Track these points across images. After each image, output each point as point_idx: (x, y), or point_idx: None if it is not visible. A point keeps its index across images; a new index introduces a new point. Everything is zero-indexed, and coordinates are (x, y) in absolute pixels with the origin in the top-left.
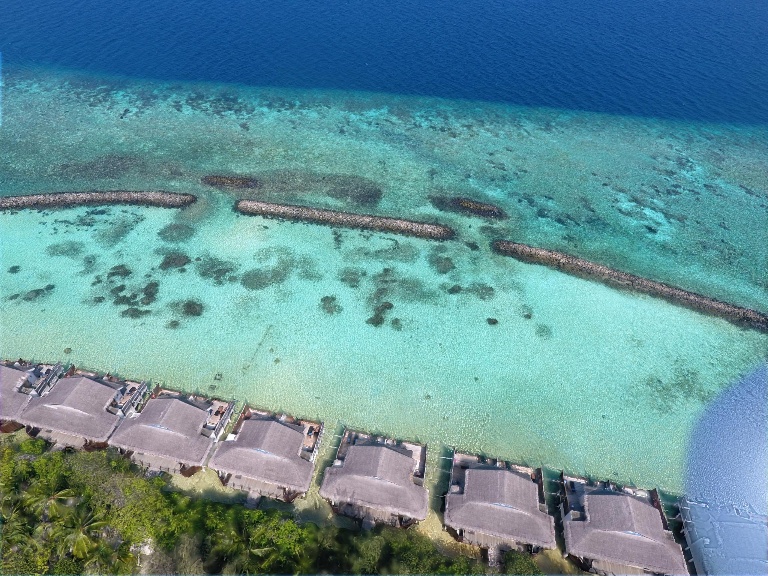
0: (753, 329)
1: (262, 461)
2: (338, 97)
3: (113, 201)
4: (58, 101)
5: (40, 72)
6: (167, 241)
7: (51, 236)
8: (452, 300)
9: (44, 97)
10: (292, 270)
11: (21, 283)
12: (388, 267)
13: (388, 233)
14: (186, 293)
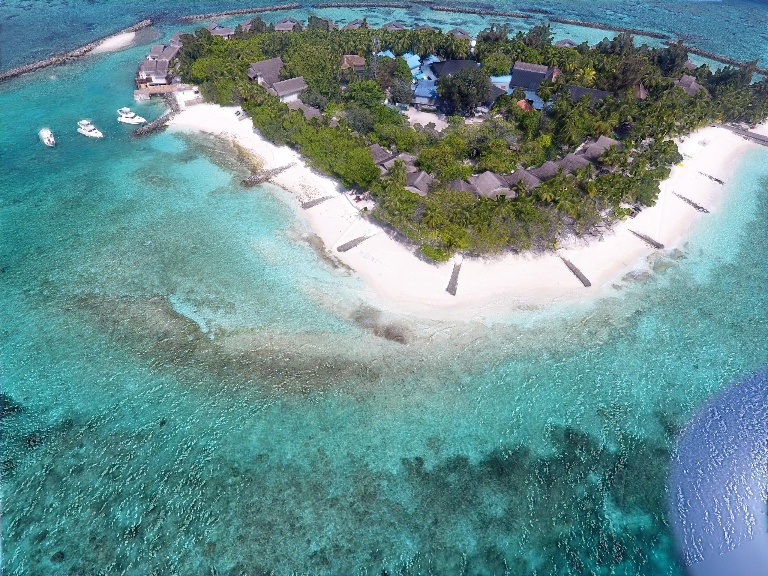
0: (658, 38)
1: None
2: None
3: (377, 6)
4: None
5: None
6: None
7: (361, 13)
8: None
9: None
10: None
11: None
12: (508, 23)
13: (503, 16)
14: None
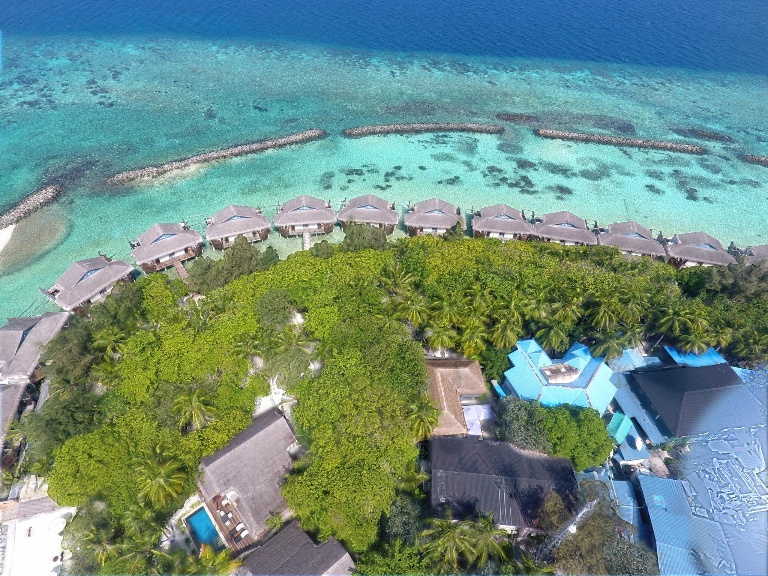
0: None
1: (704, 252)
2: (543, 63)
3: (447, 129)
4: (334, 65)
5: (297, 45)
6: (508, 153)
7: (426, 150)
8: (735, 188)
9: (320, 62)
10: (611, 170)
11: (436, 175)
12: (676, 169)
13: (659, 150)
14: (551, 182)
